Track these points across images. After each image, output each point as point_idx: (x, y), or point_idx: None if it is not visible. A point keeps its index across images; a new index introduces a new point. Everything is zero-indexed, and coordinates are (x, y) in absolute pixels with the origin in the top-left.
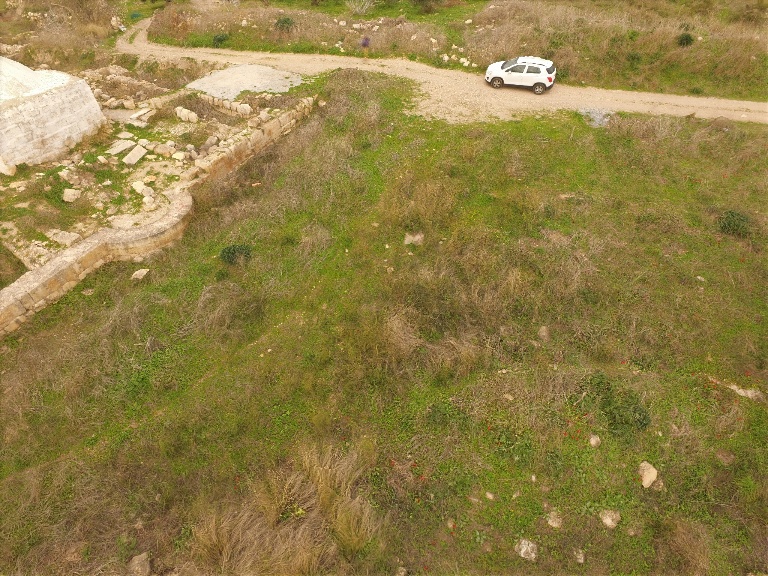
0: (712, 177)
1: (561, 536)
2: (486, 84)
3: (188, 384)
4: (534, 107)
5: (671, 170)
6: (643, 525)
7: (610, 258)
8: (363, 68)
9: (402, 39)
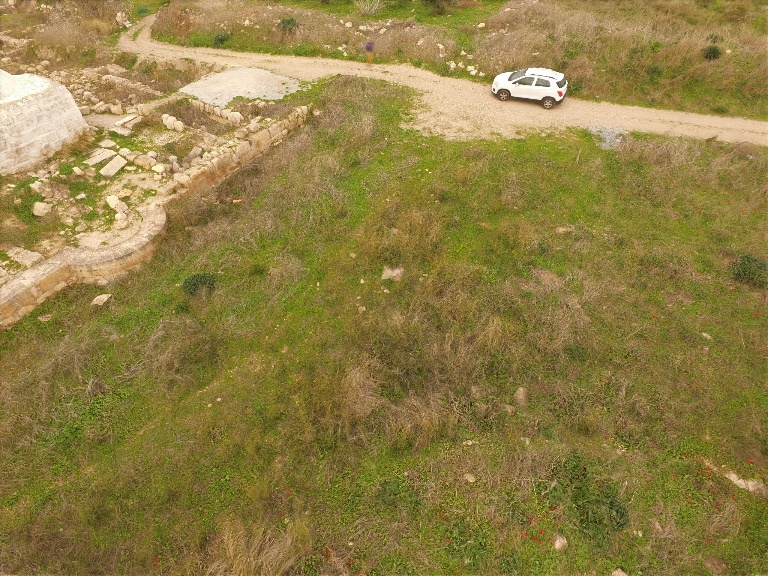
0: (730, 213)
1: None
2: (492, 96)
3: (125, 436)
4: (541, 123)
5: (684, 203)
6: None
7: (606, 306)
8: (364, 74)
9: (408, 44)
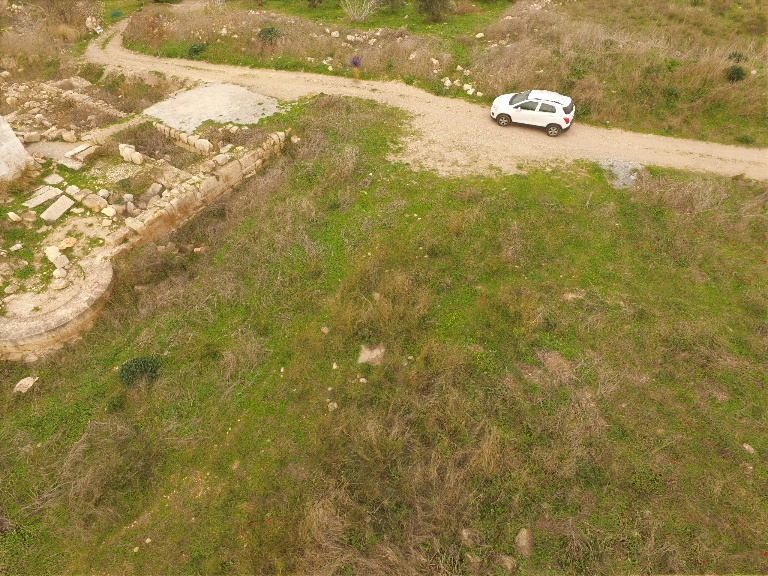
0: (765, 274)
1: None
2: (491, 120)
3: None
4: (545, 155)
5: (712, 260)
6: None
7: (625, 404)
8: (350, 93)
9: (399, 57)
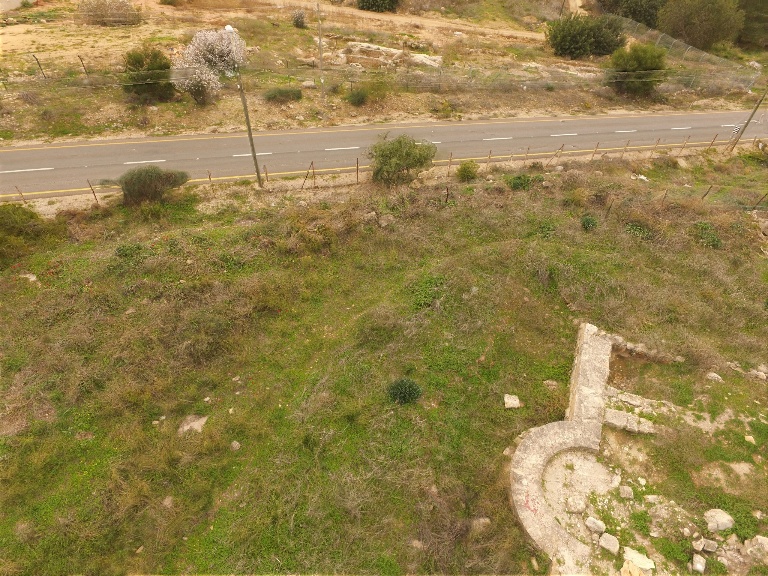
0: None
1: None
2: None
3: None
4: None
5: None
6: None
7: None
8: None
9: None
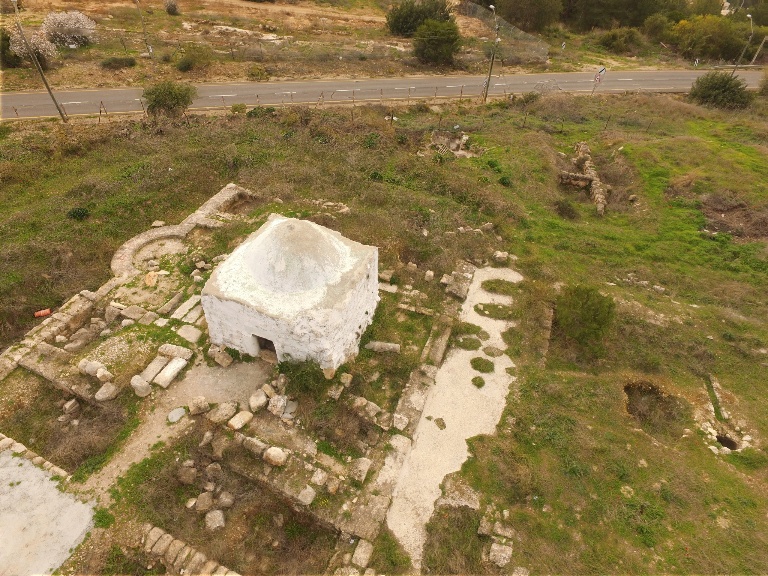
0: None
1: None
2: None
3: None
4: None
5: None
6: None
7: None
8: None
9: None
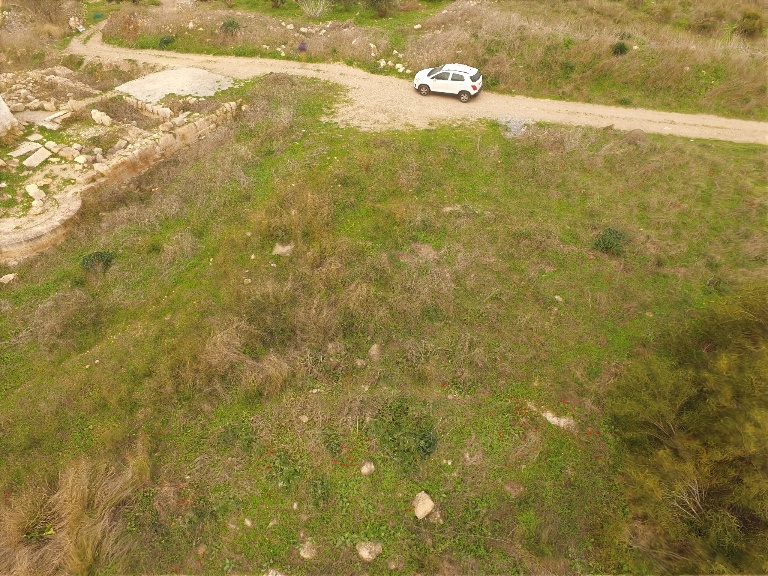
0: (608, 192)
1: (312, 567)
2: (415, 91)
3: (2, 394)
4: (455, 115)
5: (568, 184)
6: (407, 558)
7: (473, 274)
8: (298, 73)
9: (343, 44)
